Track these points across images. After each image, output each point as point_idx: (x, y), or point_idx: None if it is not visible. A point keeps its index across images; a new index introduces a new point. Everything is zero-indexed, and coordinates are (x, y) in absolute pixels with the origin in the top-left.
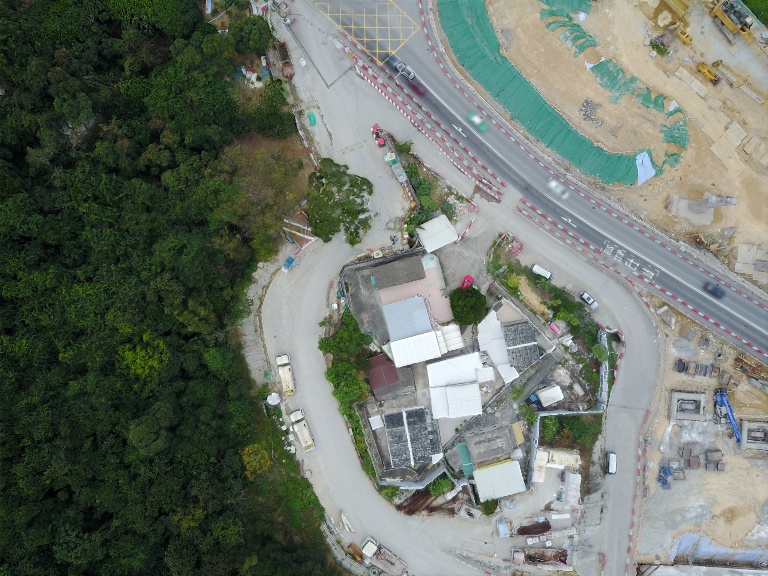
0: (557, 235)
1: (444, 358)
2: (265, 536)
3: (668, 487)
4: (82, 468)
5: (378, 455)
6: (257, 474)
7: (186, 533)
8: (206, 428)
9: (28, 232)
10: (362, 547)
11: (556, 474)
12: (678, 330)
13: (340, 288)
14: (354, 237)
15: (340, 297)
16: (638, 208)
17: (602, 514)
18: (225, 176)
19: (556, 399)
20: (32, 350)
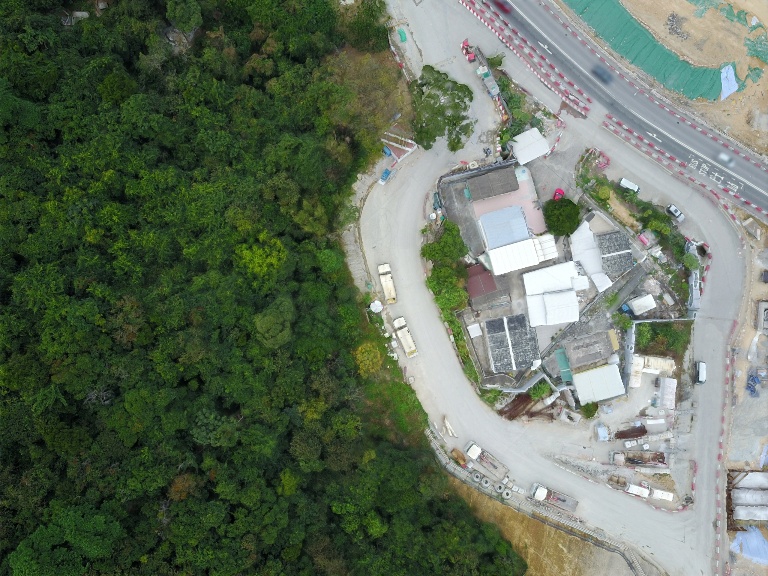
0: (643, 149)
1: (538, 268)
2: (375, 437)
3: (756, 395)
4: (213, 356)
5: (477, 363)
6: (369, 374)
7: (309, 426)
8: (322, 326)
9: (147, 132)
10: (466, 450)
11: (650, 381)
12: (763, 241)
13: (437, 199)
14: (457, 143)
15: (437, 208)
16: (721, 123)
17: (692, 422)
18: (336, 78)
19: (649, 307)
20: (158, 245)
